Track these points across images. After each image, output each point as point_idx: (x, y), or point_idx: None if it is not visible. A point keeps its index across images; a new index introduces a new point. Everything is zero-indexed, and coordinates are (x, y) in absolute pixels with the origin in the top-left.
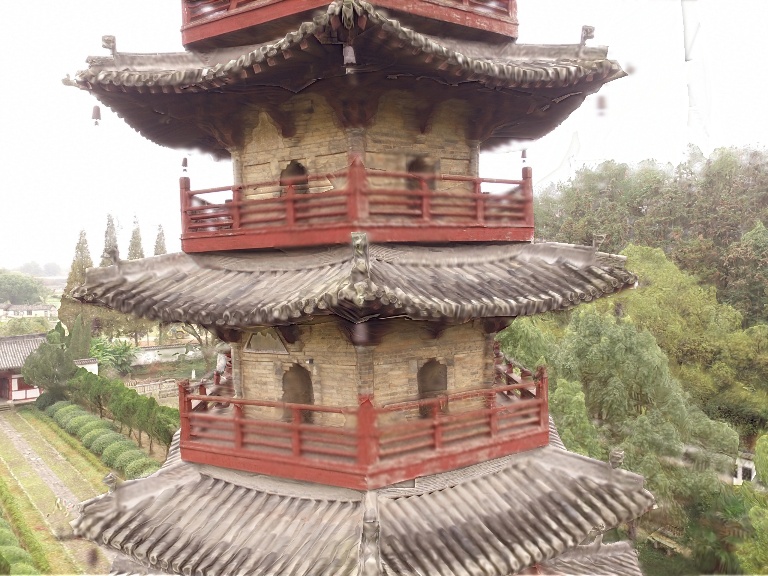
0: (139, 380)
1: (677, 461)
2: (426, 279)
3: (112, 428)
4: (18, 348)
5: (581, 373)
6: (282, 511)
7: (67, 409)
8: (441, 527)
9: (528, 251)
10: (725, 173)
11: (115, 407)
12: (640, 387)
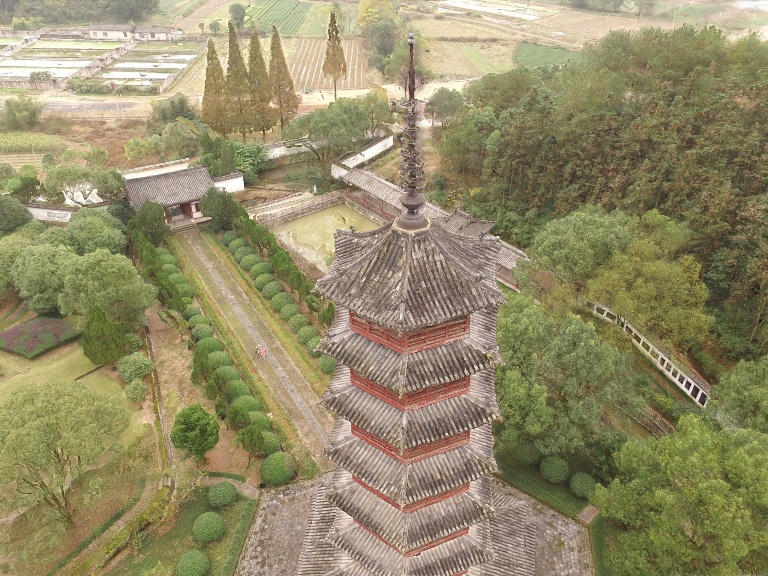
0: (274, 185)
1: (594, 426)
2: (426, 520)
3: (271, 271)
4: (190, 180)
5: (556, 367)
6: (384, 548)
7: (237, 244)
8: (427, 565)
9: (466, 493)
10: None
11: (273, 264)
12: (588, 382)
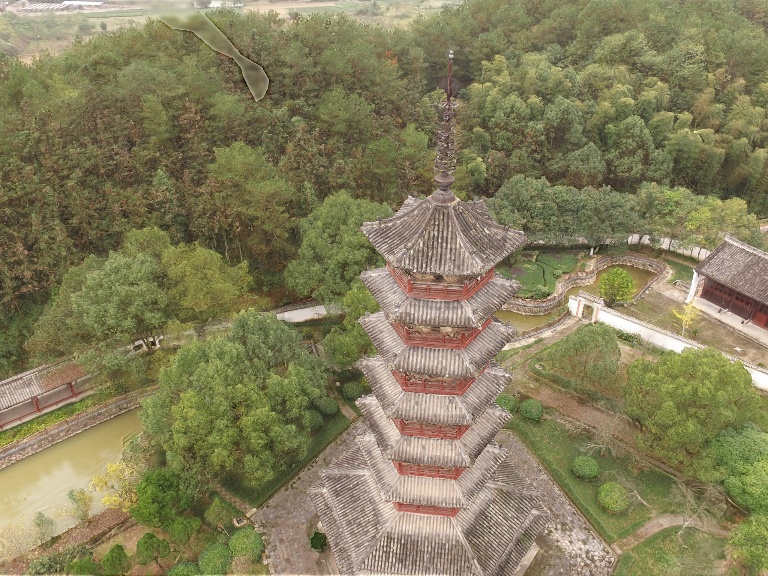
0: None
1: None
2: None
3: None
4: None
5: None
6: None
7: None
8: None
9: None
10: (81, 112)
11: None
12: None
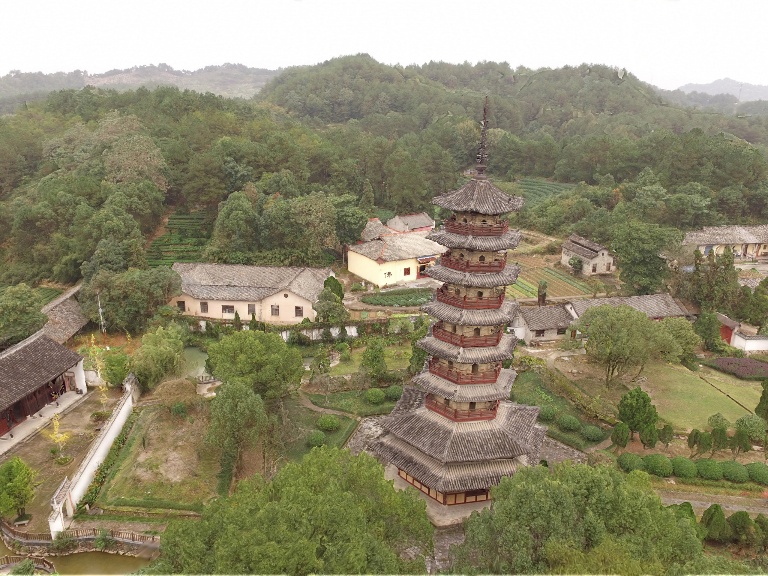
0: None
1: None
2: None
3: None
4: None
5: None
6: None
7: None
8: None
9: None
10: None
11: None
12: None
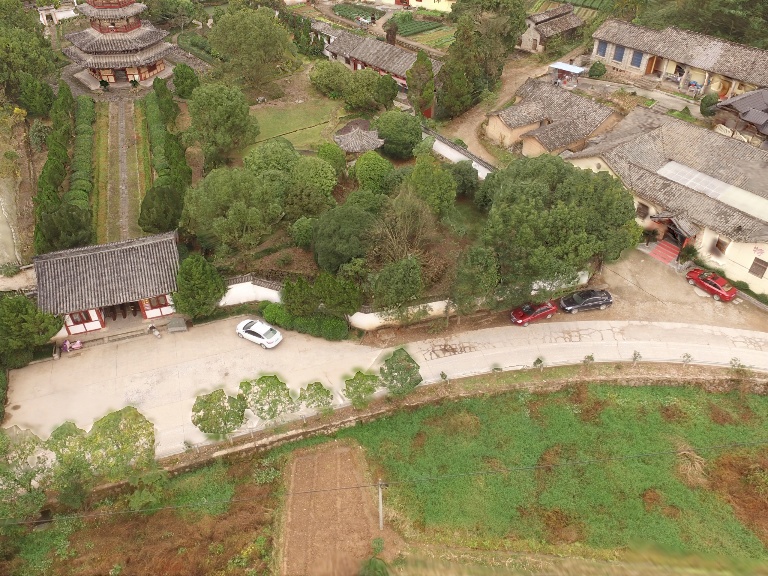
0: None
1: None
2: None
3: None
4: None
5: None
6: None
7: None
8: None
9: None
10: None
11: None
12: None
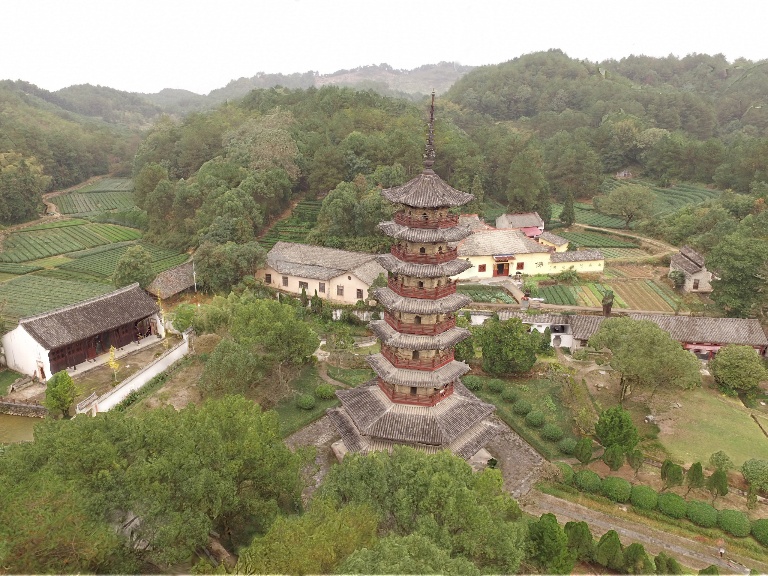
0: None
1: None
2: None
3: None
4: None
5: None
6: None
7: None
8: None
9: None
10: None
11: None
12: None
